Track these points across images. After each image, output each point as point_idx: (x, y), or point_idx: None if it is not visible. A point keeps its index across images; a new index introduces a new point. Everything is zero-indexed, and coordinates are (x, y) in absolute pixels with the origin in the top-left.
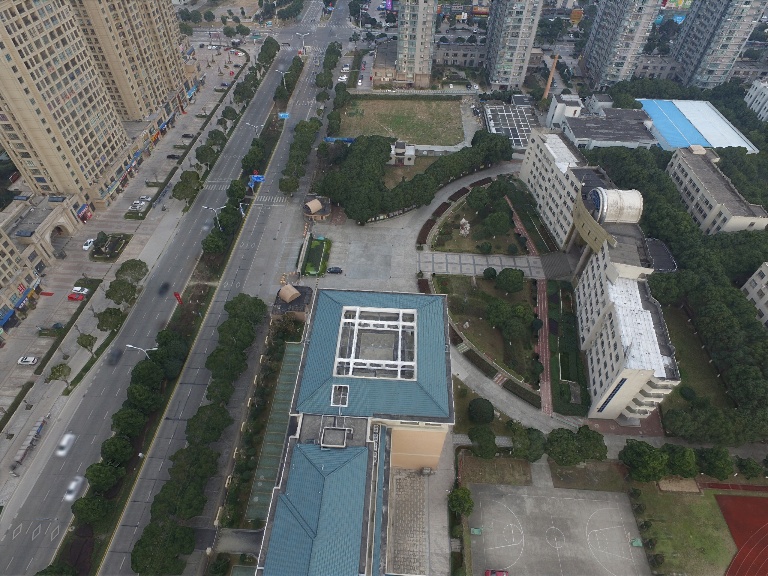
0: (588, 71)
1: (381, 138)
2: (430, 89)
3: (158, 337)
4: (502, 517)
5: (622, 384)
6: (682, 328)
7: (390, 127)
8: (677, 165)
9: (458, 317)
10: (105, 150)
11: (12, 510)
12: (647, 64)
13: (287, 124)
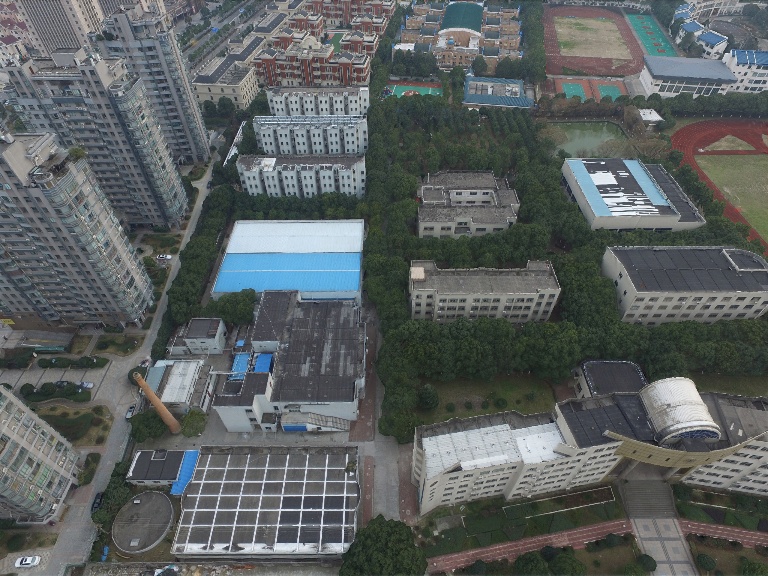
0: None
1: None
2: None
3: None
4: None
5: None
6: None
7: None
8: (438, 302)
9: None
10: None
11: None
12: None
13: None
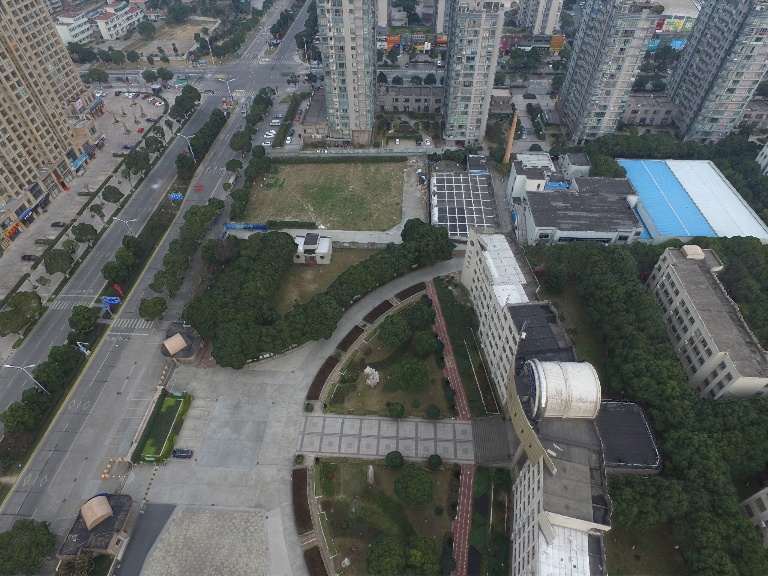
0: (565, 117)
1: (280, 236)
2: (372, 146)
3: None
4: None
5: None
6: (666, 562)
7: (312, 204)
8: (665, 274)
9: (338, 542)
10: None
11: None
12: (636, 108)
13: (186, 203)
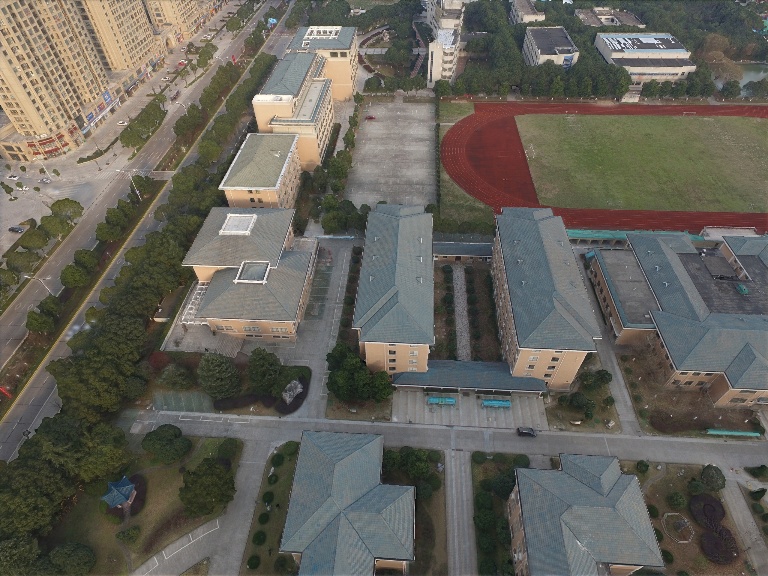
0: None
1: (344, 1)
2: None
3: (227, 65)
4: (378, 108)
5: (433, 56)
6: (489, 66)
7: None
8: (512, 4)
9: (375, 66)
10: (188, 7)
11: (172, 111)
12: None
13: (290, 7)
